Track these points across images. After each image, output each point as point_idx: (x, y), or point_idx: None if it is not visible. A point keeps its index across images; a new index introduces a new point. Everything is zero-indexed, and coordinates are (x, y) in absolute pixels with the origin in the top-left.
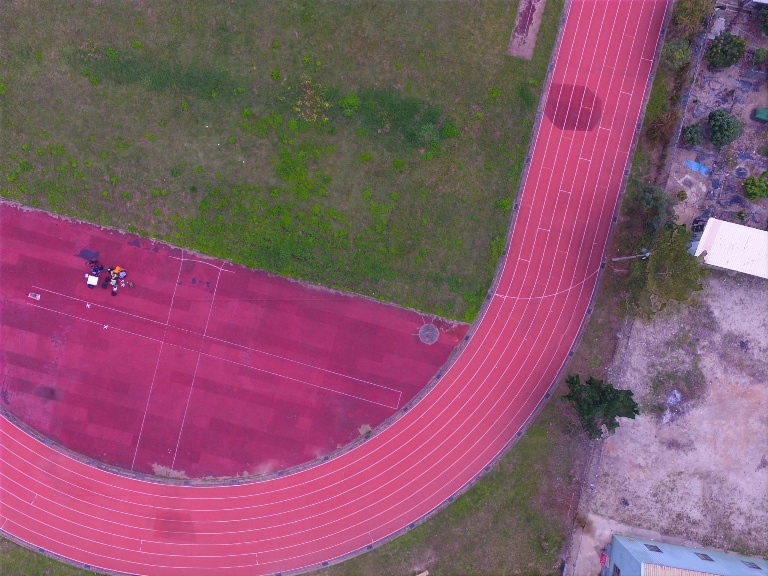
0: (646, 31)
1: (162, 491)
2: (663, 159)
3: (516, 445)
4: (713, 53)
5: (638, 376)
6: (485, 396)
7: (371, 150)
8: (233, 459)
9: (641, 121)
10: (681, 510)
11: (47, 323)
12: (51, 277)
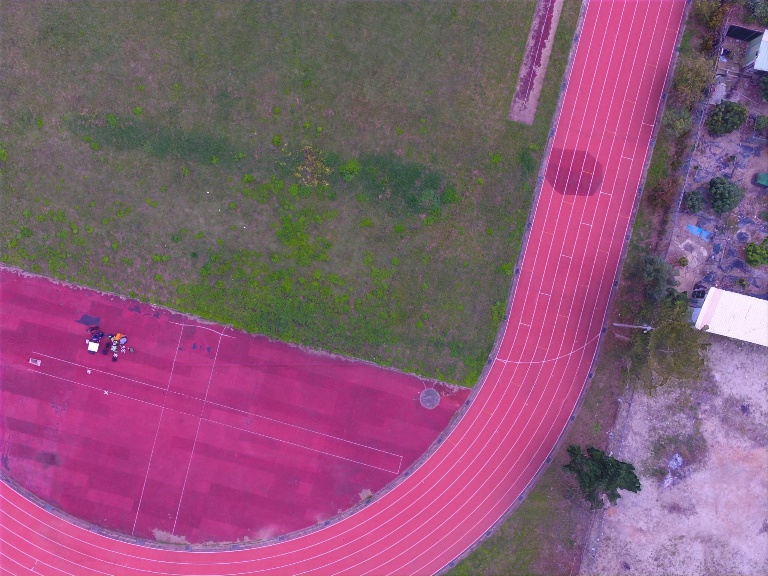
0: (647, 96)
1: (162, 556)
2: (664, 225)
3: (517, 510)
4: (714, 121)
5: (639, 440)
6: (486, 461)
7: (372, 215)
8: (234, 524)
9: (642, 186)
10: (683, 574)
11: (48, 389)
12: (52, 343)
